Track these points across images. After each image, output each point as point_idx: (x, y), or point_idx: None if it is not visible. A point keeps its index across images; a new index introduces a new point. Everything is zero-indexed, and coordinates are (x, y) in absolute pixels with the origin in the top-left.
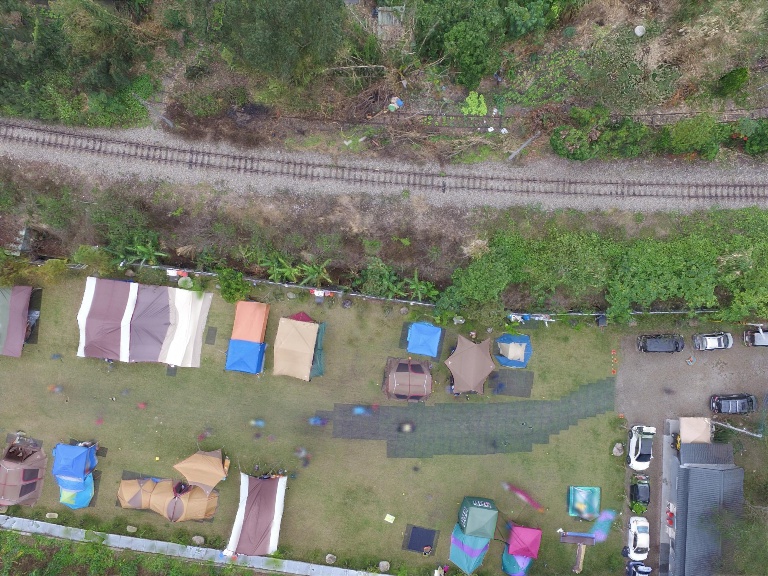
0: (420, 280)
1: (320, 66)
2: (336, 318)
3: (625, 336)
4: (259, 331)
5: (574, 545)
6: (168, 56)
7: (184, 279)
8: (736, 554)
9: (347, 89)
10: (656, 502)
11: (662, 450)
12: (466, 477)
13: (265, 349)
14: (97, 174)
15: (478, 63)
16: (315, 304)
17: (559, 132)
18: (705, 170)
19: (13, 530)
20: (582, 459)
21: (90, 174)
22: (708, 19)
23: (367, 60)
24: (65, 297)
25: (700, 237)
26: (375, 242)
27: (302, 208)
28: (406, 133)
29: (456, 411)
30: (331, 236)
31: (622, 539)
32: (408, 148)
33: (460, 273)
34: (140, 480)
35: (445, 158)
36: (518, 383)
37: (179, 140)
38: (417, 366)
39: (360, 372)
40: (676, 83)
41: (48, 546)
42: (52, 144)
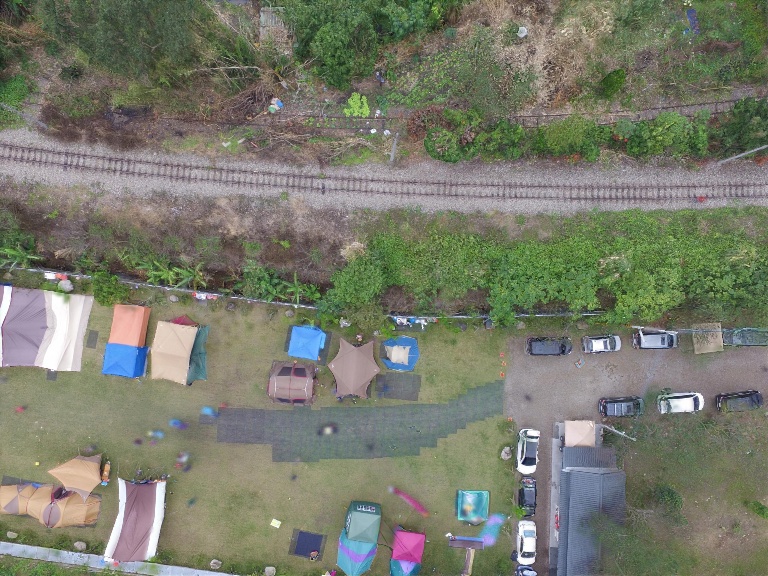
0: (303, 283)
1: (185, 67)
2: (220, 321)
3: (514, 339)
4: (137, 335)
5: (463, 549)
6: (47, 57)
7: (64, 282)
8: (627, 558)
9: (227, 90)
10: (545, 506)
11: (551, 453)
12: (353, 481)
13: (147, 353)
14: None
15: (341, 64)
16: (199, 307)
17: (431, 134)
18: (588, 172)
19: None
20: (471, 463)
21: None
22: (589, 20)
23: (241, 61)
24: None
25: (582, 239)
26: (256, 245)
27: (180, 210)
28: (283, 135)
29: (343, 415)
30: (210, 239)
31: (511, 543)
32: (287, 150)
33: (338, 276)
34: (19, 485)
35: (325, 160)
36: (405, 386)
37: (54, 142)
38: (301, 369)
39: (245, 376)
40: (561, 84)
41: None
42: None
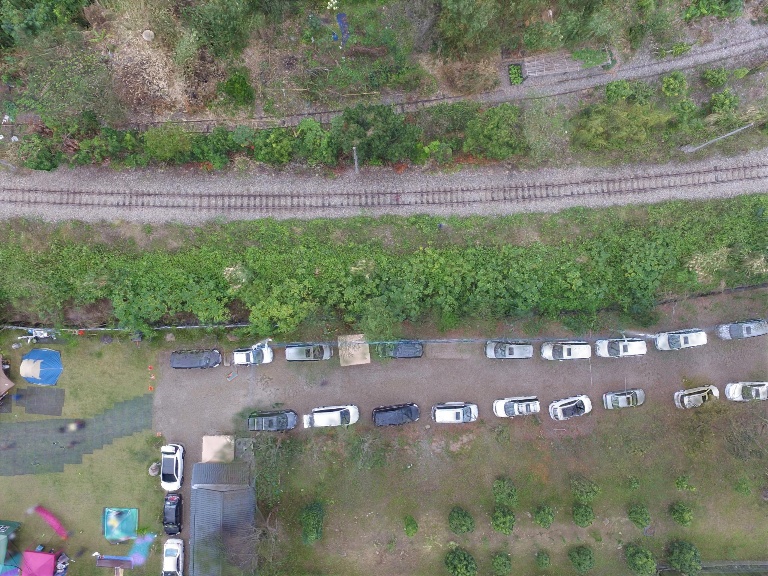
0: None
1: None
2: None
3: (163, 351)
4: None
5: (111, 569)
6: None
7: None
8: (284, 575)
9: None
10: None
11: None
12: None
13: None
14: None
15: None
16: None
17: None
18: (222, 179)
19: None
20: (118, 479)
21: None
22: None
23: None
24: None
25: (211, 249)
26: None
27: None
28: None
29: None
30: None
31: (162, 562)
32: None
33: None
34: None
35: None
36: (48, 401)
37: None
38: None
39: None
40: (202, 89)
41: None
42: None
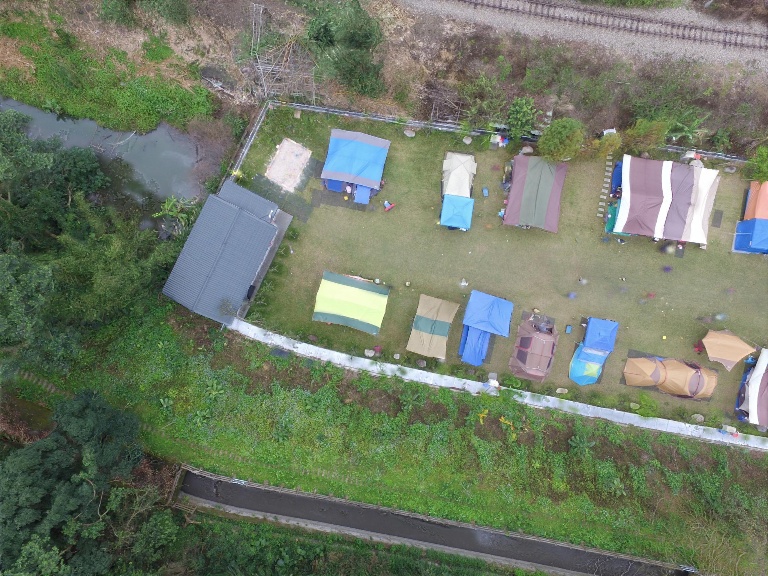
0: None
1: None
2: None
3: None
4: None
5: None
6: None
7: (696, 162)
8: None
9: None
10: None
11: None
12: None
13: None
14: (631, 54)
15: None
16: None
17: None
18: None
19: (527, 404)
20: None
21: (625, 54)
22: None
23: None
24: (580, 179)
25: None
26: None
27: None
28: None
29: None
30: None
31: None
32: None
33: None
34: (648, 358)
35: None
36: None
37: (713, 20)
38: None
39: None
40: None
41: (562, 419)
42: (594, 23)
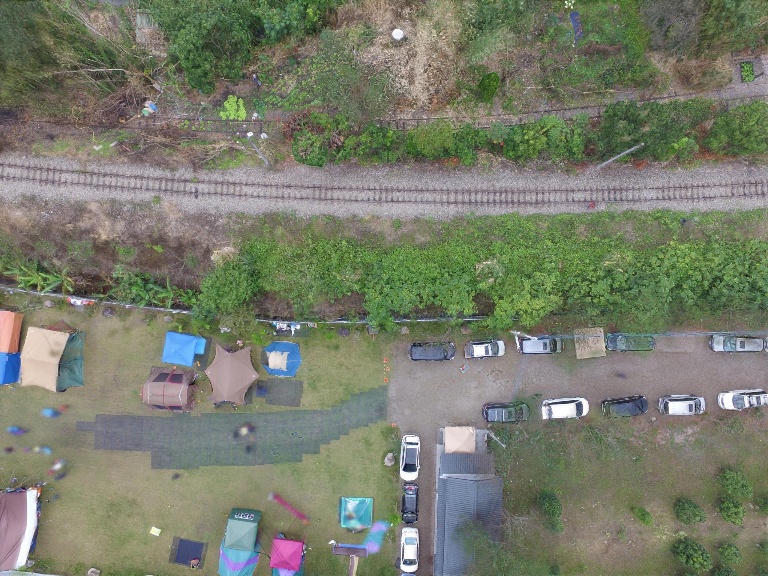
0: (180, 288)
1: (41, 70)
2: (97, 327)
3: (398, 344)
4: (7, 341)
5: (347, 557)
6: None
7: None
8: (513, 564)
9: (99, 93)
10: (430, 512)
11: (435, 460)
12: (234, 488)
13: None
14: None
15: (197, 67)
16: (75, 312)
17: (297, 137)
18: (467, 176)
19: None
20: (354, 469)
21: None
22: None
23: (108, 63)
24: None
25: (459, 244)
26: (129, 249)
27: (50, 215)
28: (154, 138)
29: (223, 421)
30: (83, 243)
31: (395, 550)
32: (160, 153)
33: None
34: None
35: (198, 163)
36: (287, 392)
37: None
38: (179, 376)
39: (123, 382)
40: (442, 87)
41: None
42: None
